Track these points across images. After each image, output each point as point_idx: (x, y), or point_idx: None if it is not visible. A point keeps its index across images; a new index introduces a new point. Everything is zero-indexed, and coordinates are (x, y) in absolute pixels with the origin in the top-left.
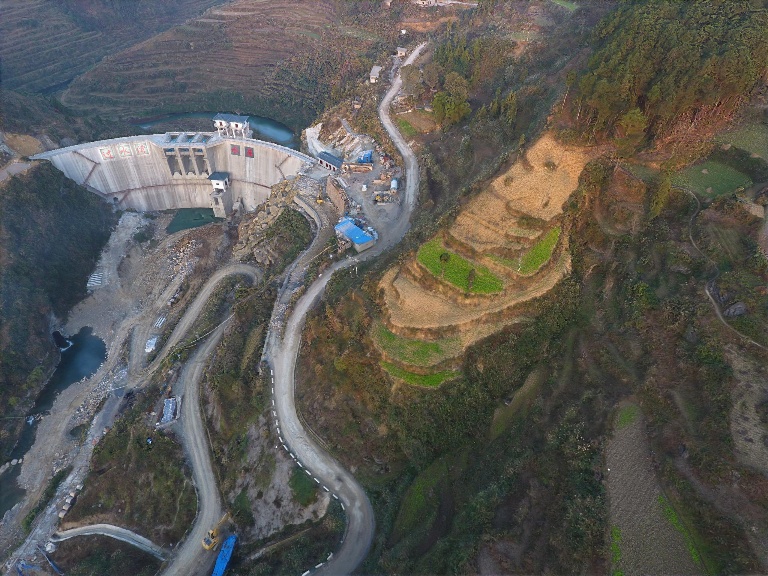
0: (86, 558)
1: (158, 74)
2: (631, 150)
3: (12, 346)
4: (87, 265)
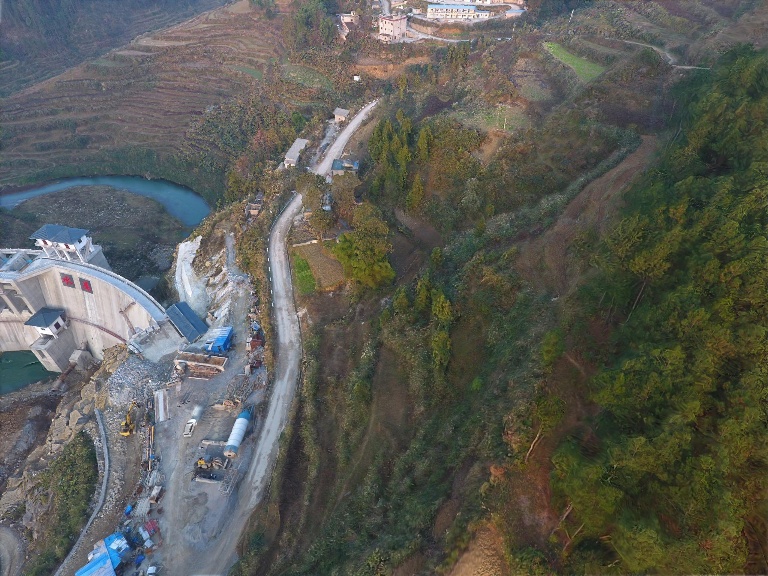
0: None
1: (54, 125)
2: None
3: None
4: None
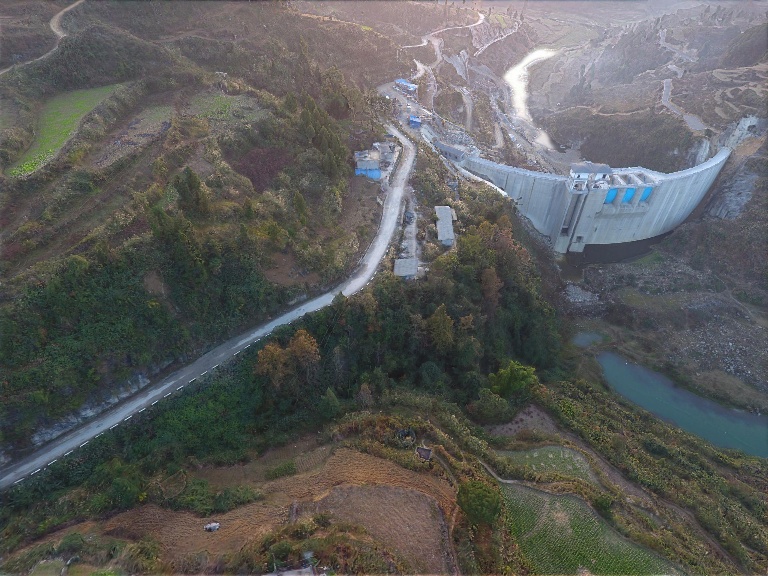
0: None
1: None
2: None
3: None
4: None
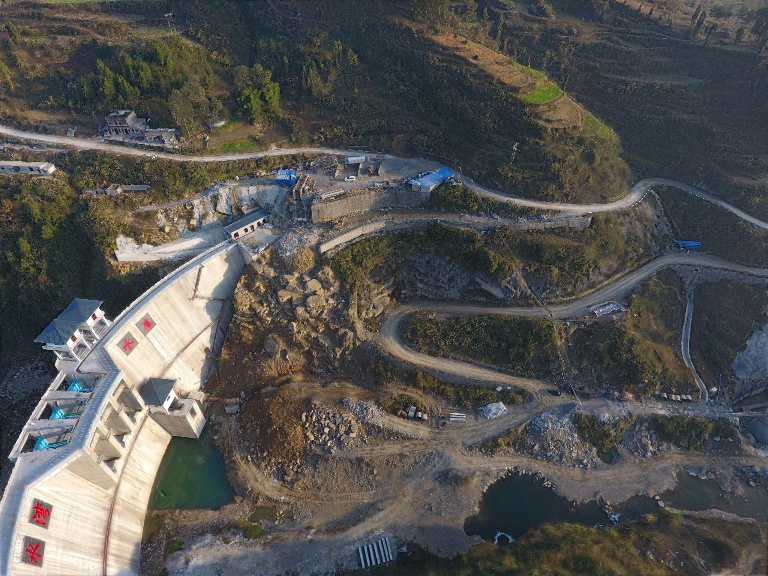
0: (708, 357)
1: None
2: (474, 14)
3: None
4: None
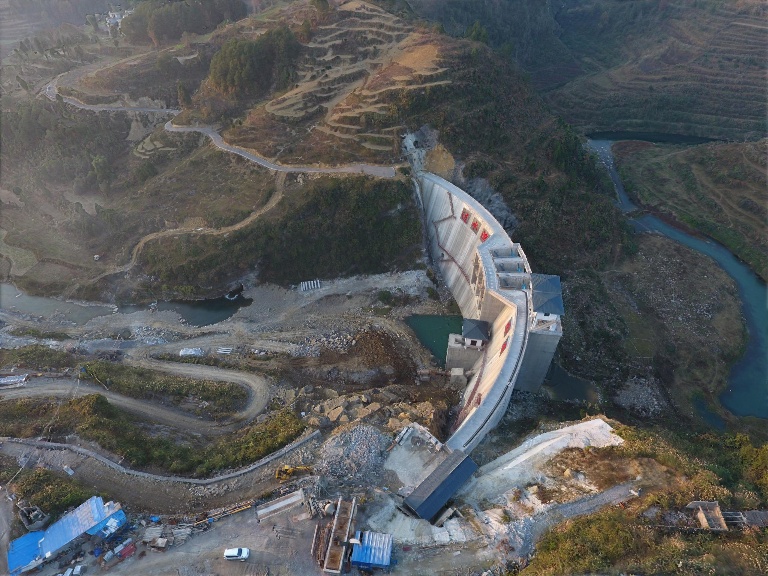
0: None
1: None
2: None
3: (198, 263)
4: (327, 272)
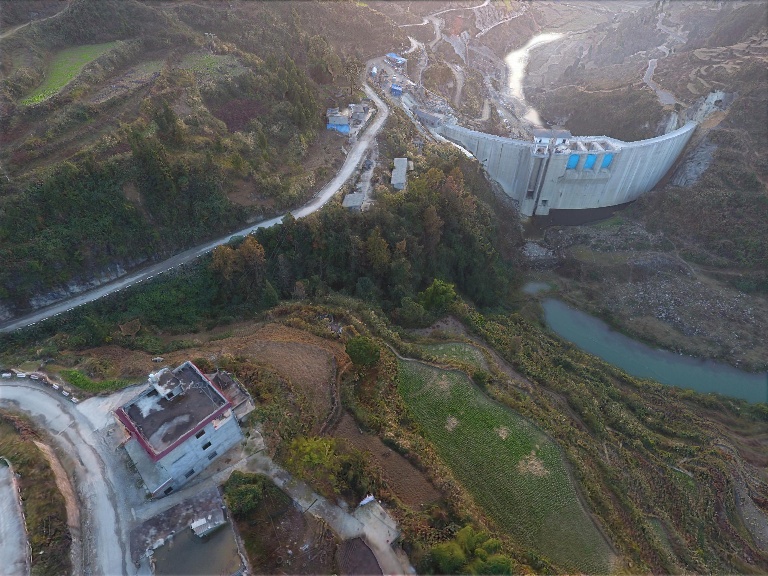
0: None
1: None
2: None
3: None
4: None
